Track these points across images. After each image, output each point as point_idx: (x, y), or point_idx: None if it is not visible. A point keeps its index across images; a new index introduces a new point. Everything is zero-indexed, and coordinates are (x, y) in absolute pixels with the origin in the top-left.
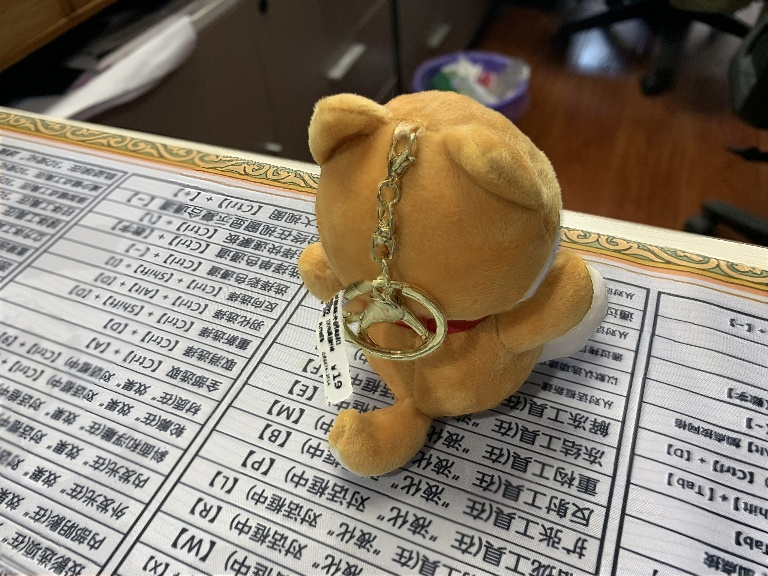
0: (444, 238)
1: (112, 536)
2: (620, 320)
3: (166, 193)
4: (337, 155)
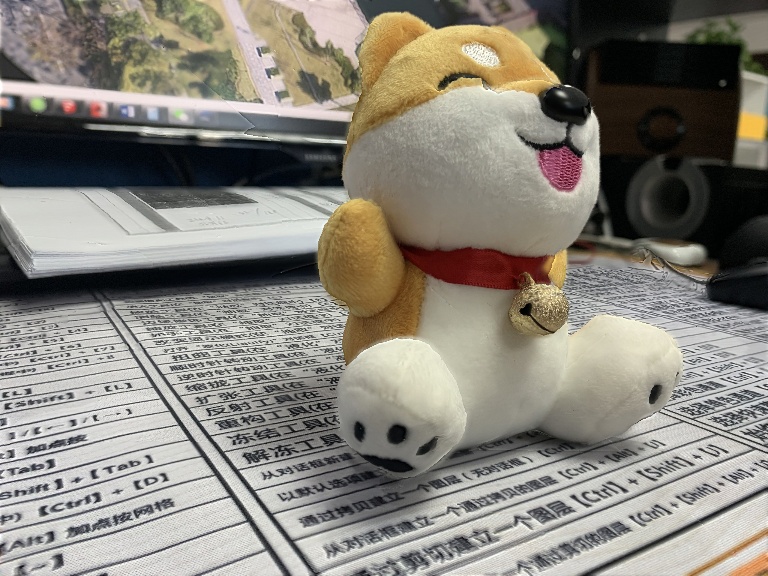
0: None
1: None
2: (361, 567)
3: None
4: None
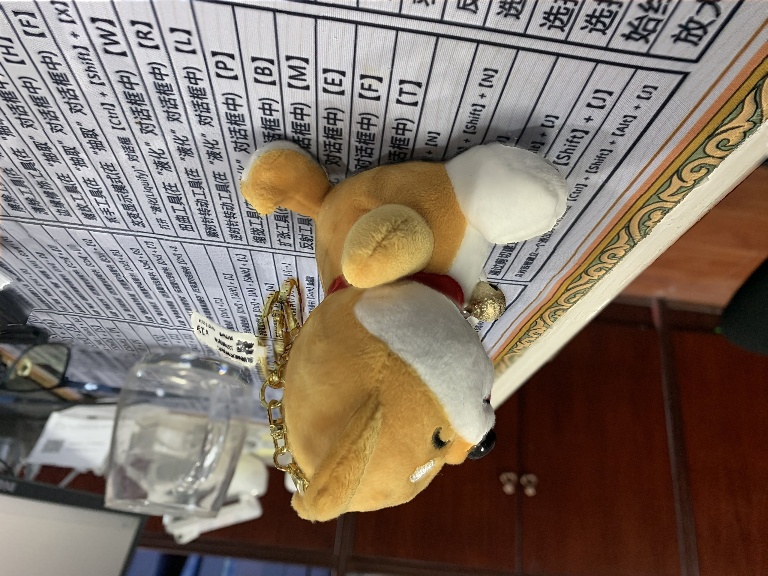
0: None
1: None
2: None
3: None
4: None
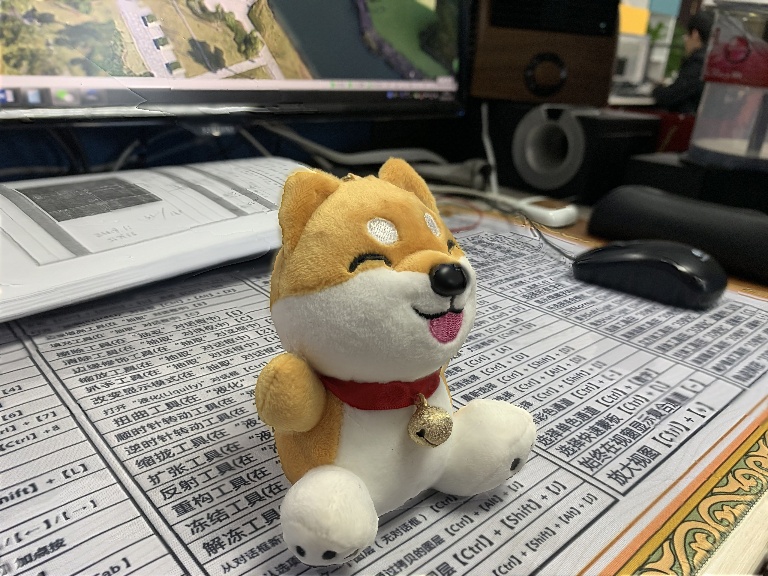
0: None
1: None
2: None
3: (704, 399)
4: None
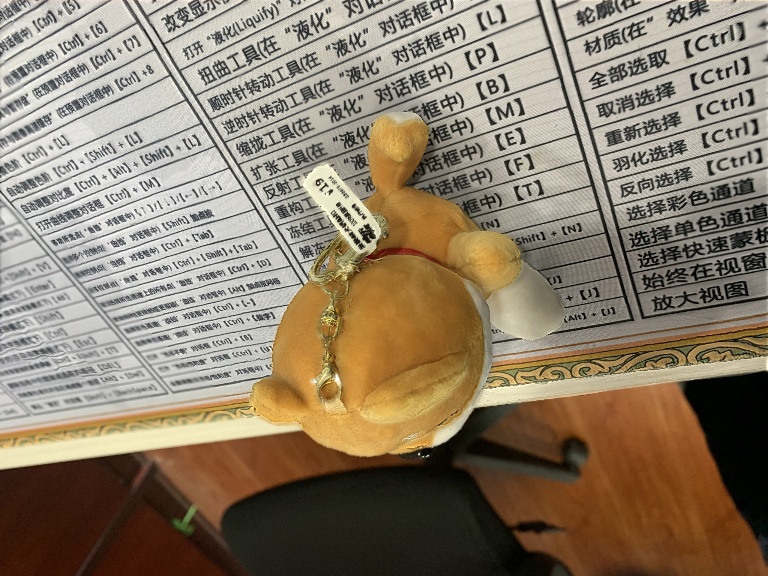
0: (296, 331)
1: None
2: None
3: None
4: (412, 366)
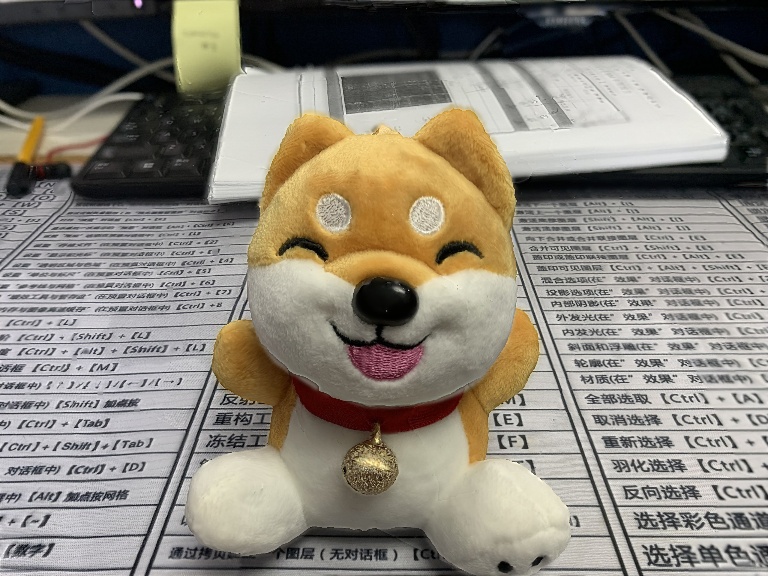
0: None
1: (550, 308)
2: None
3: None
4: None
